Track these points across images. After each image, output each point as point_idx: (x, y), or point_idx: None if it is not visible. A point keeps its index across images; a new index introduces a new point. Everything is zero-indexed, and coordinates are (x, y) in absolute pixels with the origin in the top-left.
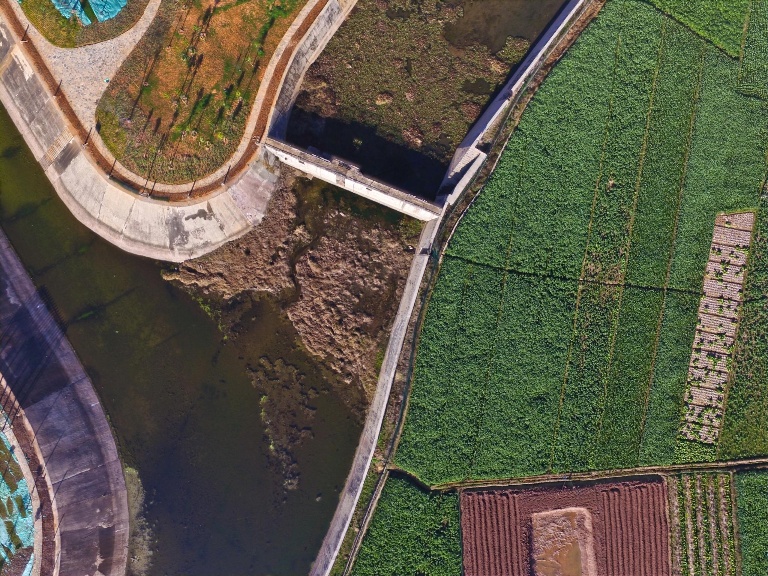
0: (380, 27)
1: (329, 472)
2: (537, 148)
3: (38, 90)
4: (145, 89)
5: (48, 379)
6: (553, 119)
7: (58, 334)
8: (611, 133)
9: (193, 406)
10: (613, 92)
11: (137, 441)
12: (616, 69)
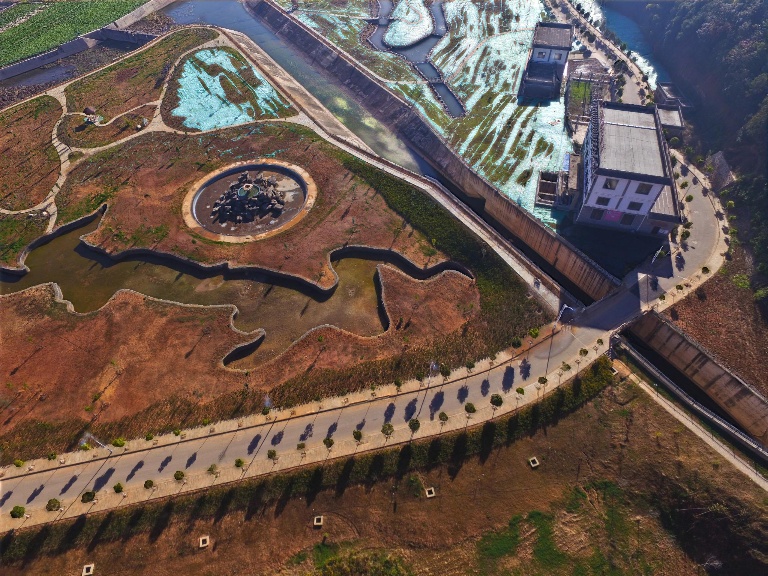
0: None
1: None
2: None
3: None
4: (198, 40)
5: (257, 7)
6: None
7: None
8: None
9: (216, 10)
10: None
11: None
12: None
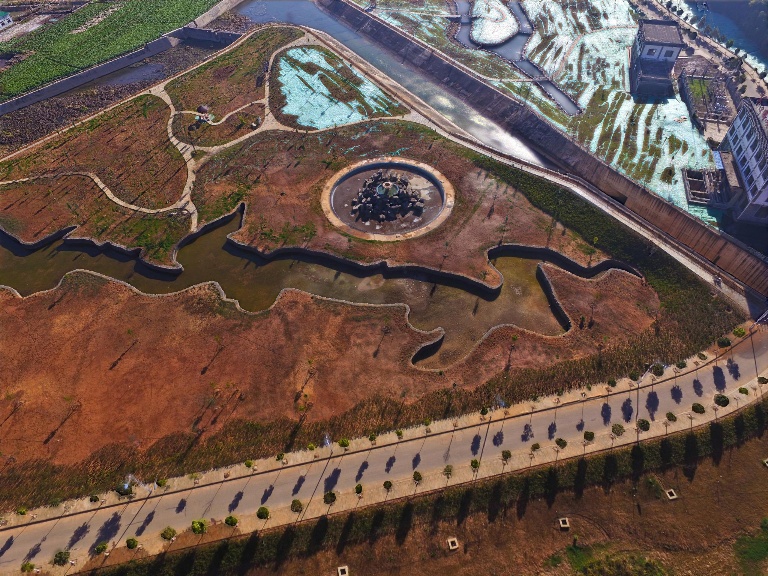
0: None
1: (247, 3)
2: None
3: None
4: None
5: None
6: None
7: (331, 15)
8: None
9: None
10: None
11: (308, 4)
12: None
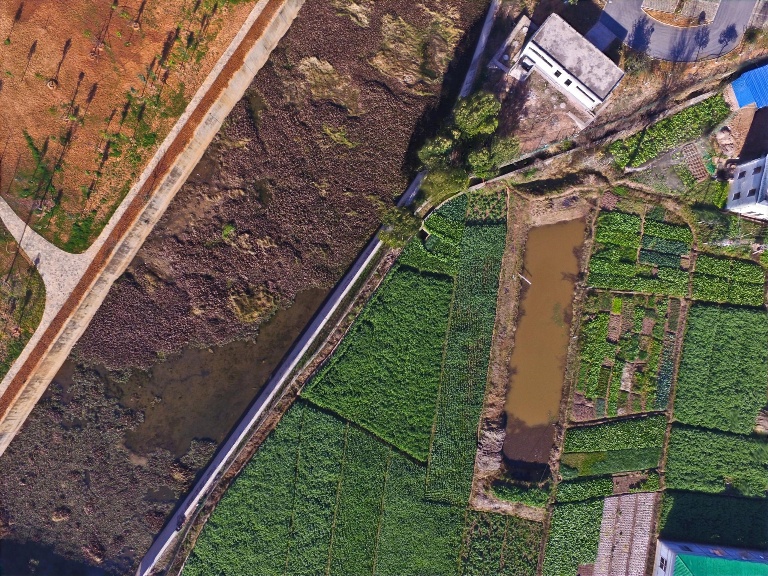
0: (55, 439)
1: None
2: (213, 574)
3: None
4: None
5: None
6: (229, 542)
7: None
8: (293, 551)
9: None
10: (294, 508)
11: None
12: (296, 484)
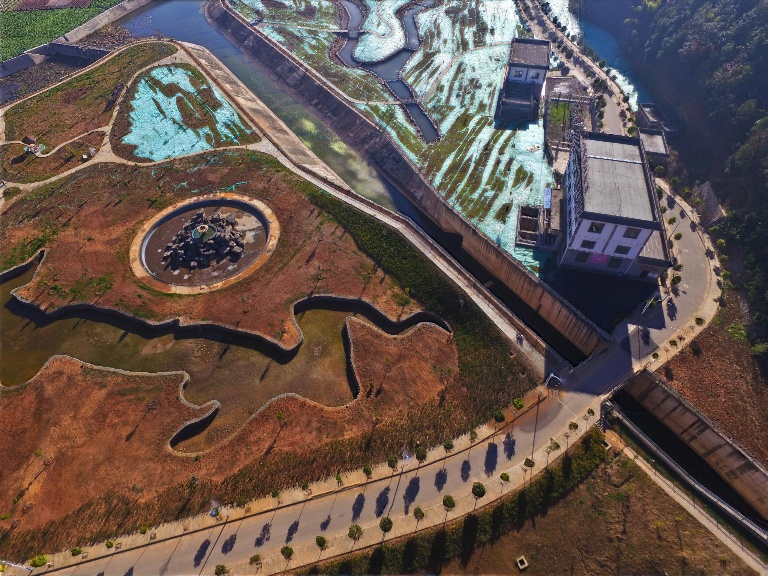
0: None
1: None
2: None
3: (200, 57)
4: (154, 56)
5: None
6: None
7: None
8: None
9: None
10: None
11: None
12: None
